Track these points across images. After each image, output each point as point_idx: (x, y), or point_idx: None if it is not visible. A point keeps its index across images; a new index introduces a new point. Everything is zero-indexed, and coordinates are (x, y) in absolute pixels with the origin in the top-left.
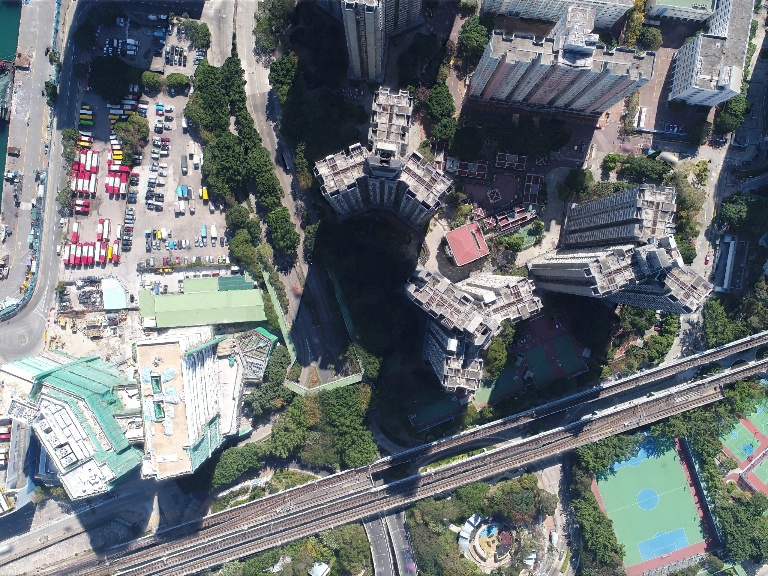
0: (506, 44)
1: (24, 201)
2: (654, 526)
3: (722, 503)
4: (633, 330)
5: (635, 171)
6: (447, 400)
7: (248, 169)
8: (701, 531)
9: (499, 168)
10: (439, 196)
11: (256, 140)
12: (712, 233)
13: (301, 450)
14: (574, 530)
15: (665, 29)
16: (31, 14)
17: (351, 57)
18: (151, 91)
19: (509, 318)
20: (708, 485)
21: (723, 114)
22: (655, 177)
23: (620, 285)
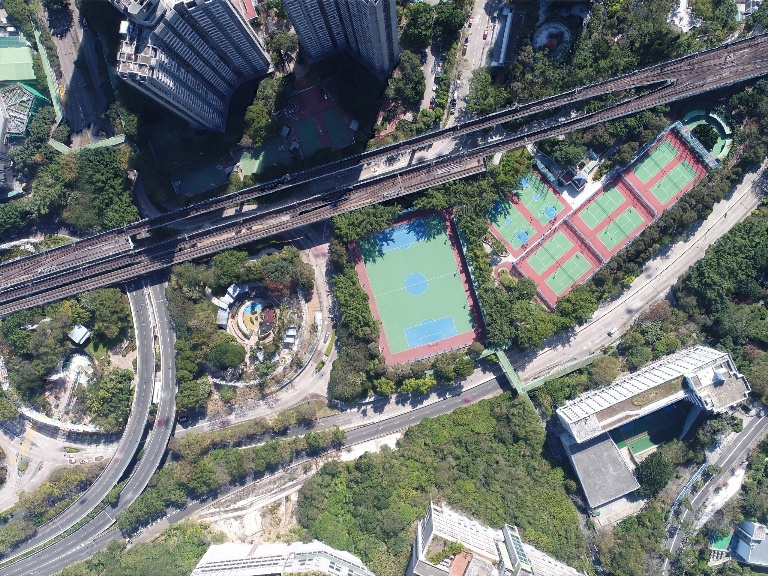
0: None
1: None
2: (422, 312)
3: (485, 285)
4: (396, 97)
5: None
6: (214, 170)
7: None
8: (470, 320)
9: None
10: None
11: None
12: (492, 7)
13: (64, 210)
14: None
15: None
16: None
17: None
18: None
19: None
20: None
21: None
22: None
23: None
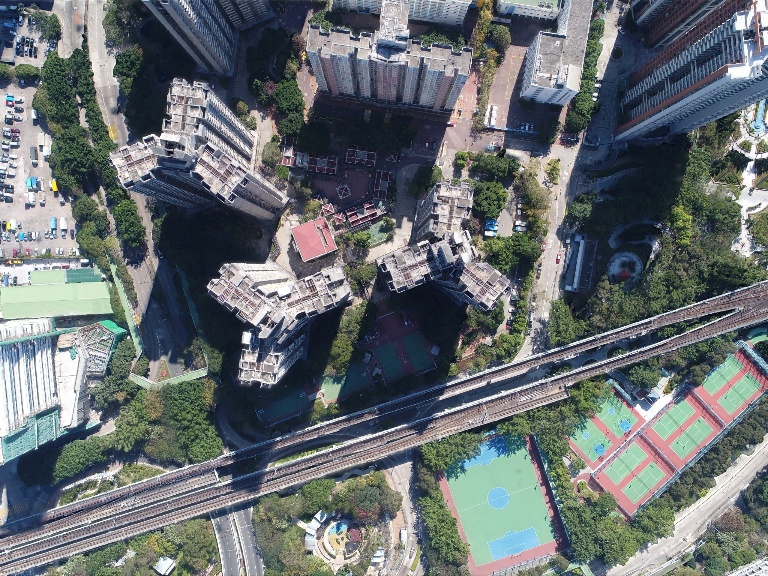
0: None
1: None
2: (505, 525)
3: (568, 503)
4: None
5: (483, 169)
6: (296, 396)
7: (91, 161)
8: (552, 531)
9: (349, 164)
10: (239, 189)
11: (102, 132)
12: (564, 232)
13: (146, 444)
14: (424, 528)
15: (517, 27)
16: None
17: None
18: (1, 82)
19: (306, 312)
20: (557, 485)
21: (571, 113)
22: (501, 175)
23: (416, 280)
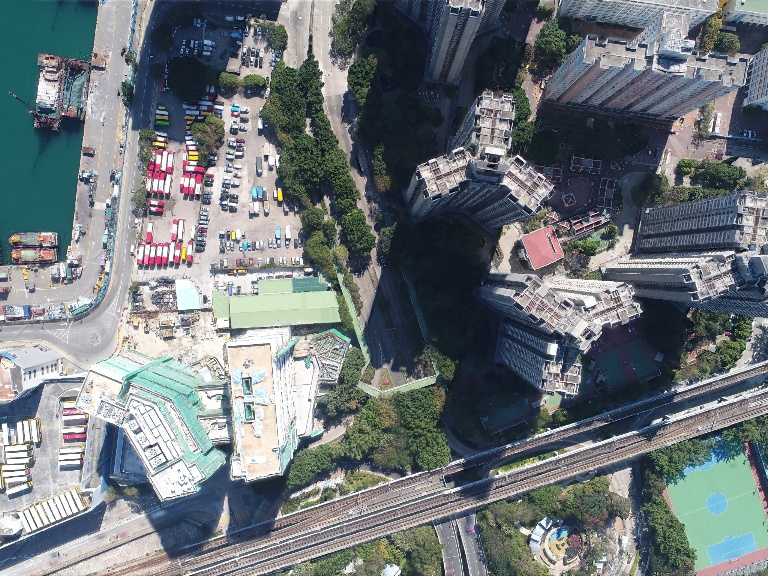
0: (599, 49)
1: (98, 201)
2: (723, 530)
3: None
4: None
5: (711, 176)
6: (519, 403)
7: (326, 171)
8: None
9: (574, 172)
10: None
11: (334, 142)
12: None
13: (374, 452)
14: (643, 534)
15: (740, 35)
16: (108, 14)
17: (434, 60)
18: (227, 92)
19: (608, 323)
20: None
21: None
22: (731, 182)
23: (720, 291)
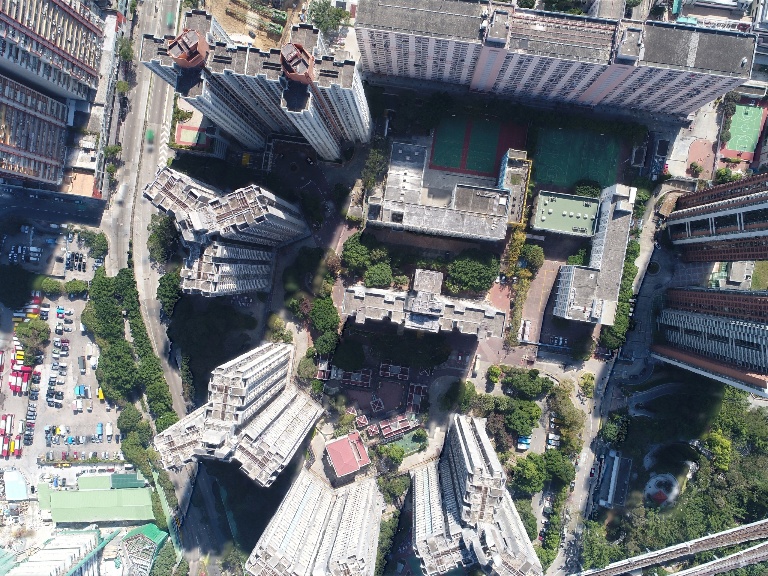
0: (358, 301)
1: None
2: None
3: None
4: None
5: None
6: None
7: (136, 379)
8: None
9: (383, 377)
10: None
11: (145, 349)
12: (598, 446)
13: None
14: None
15: (551, 242)
16: None
17: None
18: (53, 295)
19: None
20: None
21: (606, 332)
22: (534, 396)
23: (448, 567)
